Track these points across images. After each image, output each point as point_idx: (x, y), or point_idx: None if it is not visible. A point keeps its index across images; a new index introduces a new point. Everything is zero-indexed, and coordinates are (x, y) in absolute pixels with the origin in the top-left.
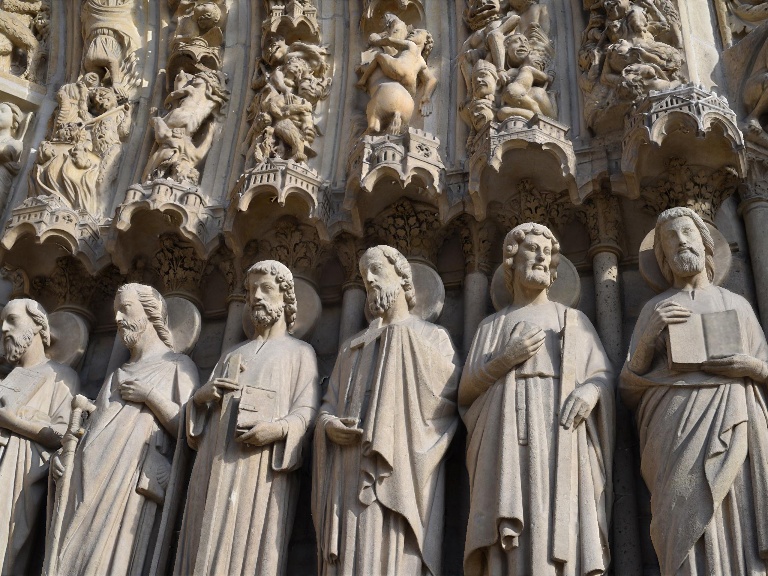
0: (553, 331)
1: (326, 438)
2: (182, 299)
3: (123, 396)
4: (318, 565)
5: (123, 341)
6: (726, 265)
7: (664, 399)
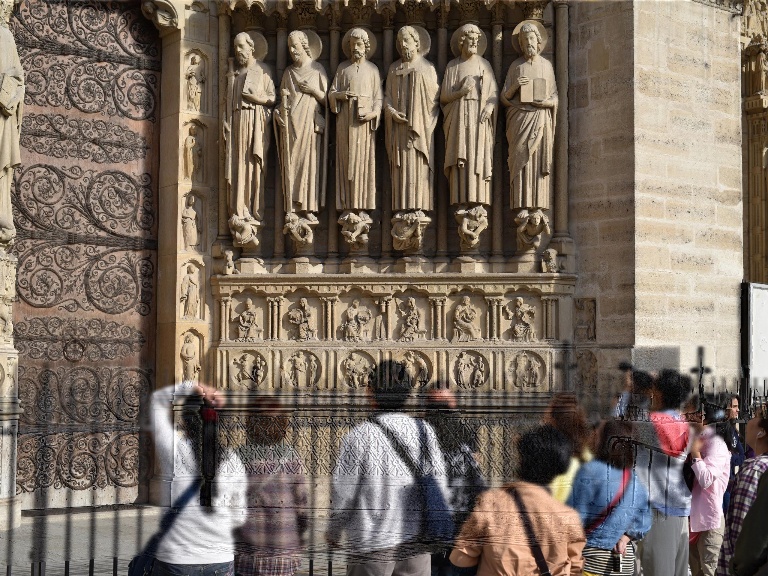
0: (478, 76)
1: (393, 120)
2: (312, 32)
3: (302, 90)
4: (390, 165)
5: (295, 60)
6: (545, 44)
7: (517, 113)
